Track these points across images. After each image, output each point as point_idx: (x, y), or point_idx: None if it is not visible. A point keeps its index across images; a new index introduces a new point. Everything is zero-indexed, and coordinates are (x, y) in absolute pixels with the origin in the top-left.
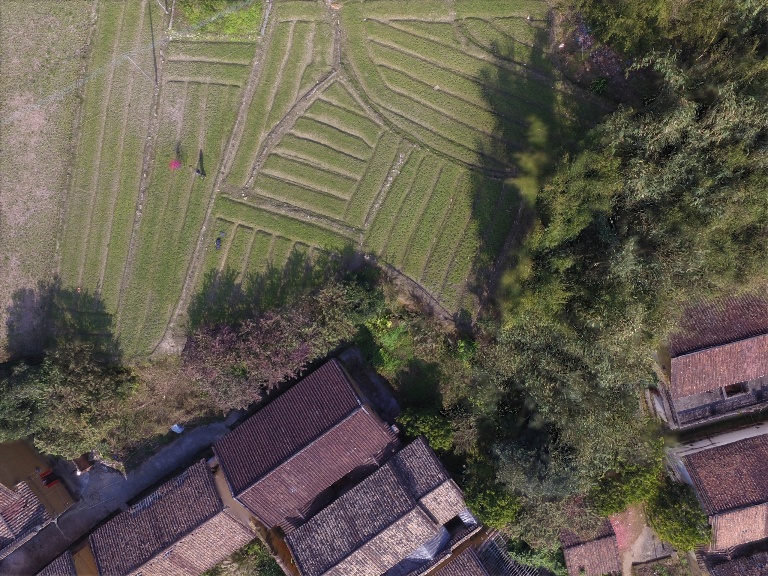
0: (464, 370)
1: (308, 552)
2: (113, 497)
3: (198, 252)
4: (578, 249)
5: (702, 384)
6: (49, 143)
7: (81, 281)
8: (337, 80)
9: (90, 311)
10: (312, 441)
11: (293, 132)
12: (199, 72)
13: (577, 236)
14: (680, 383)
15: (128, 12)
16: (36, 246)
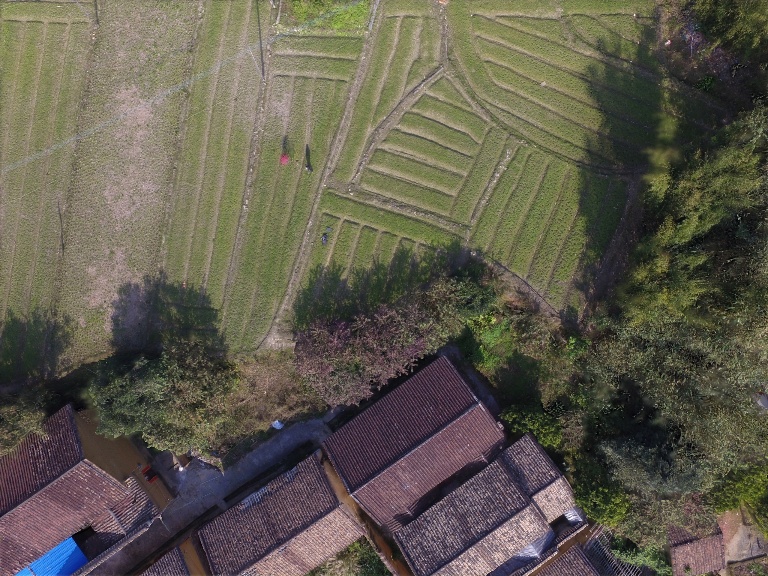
0: None
1: (419, 549)
2: (210, 493)
3: (304, 247)
4: (705, 246)
5: None
6: (155, 137)
7: (186, 276)
8: (444, 76)
9: (195, 306)
10: (429, 437)
11: (399, 127)
12: (306, 67)
13: (705, 232)
14: None
15: (235, 6)
16: (142, 240)
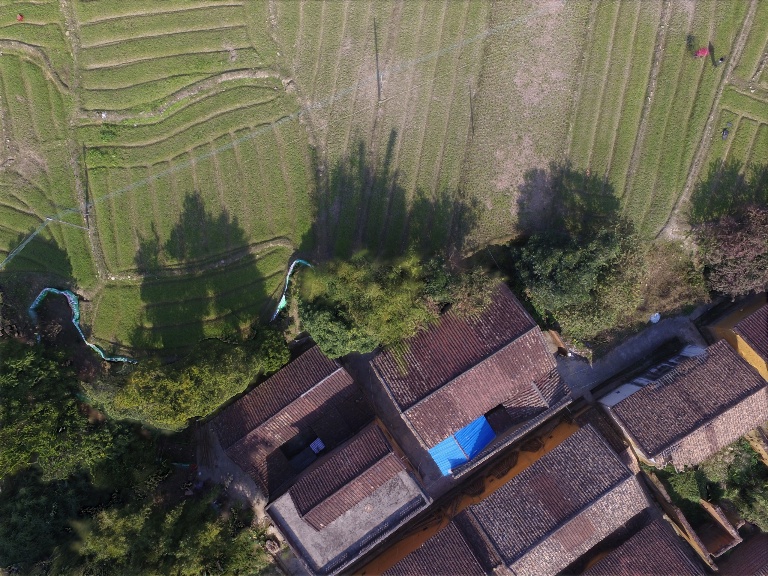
0: None
1: None
2: (578, 385)
3: (705, 141)
4: None
5: None
6: (565, 27)
7: (589, 164)
8: None
9: (598, 194)
10: None
11: None
12: None
13: None
14: None
15: None
16: (549, 127)
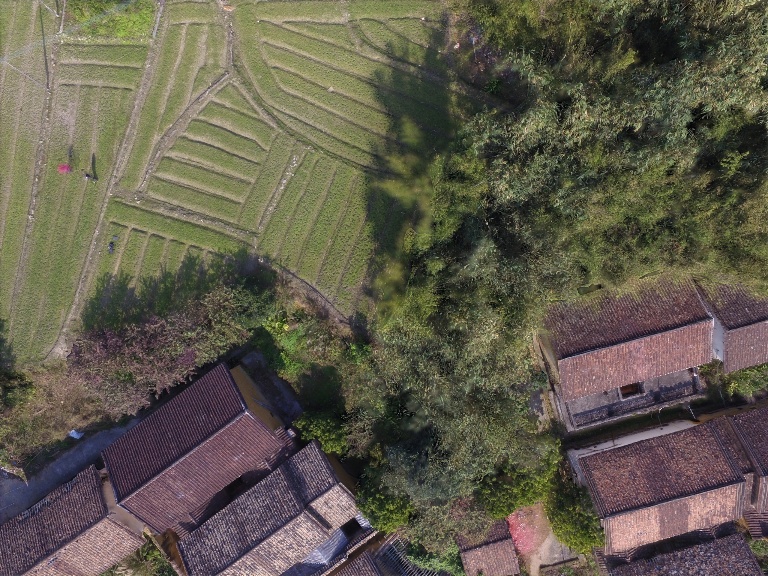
0: (367, 373)
1: (197, 558)
2: (14, 503)
3: (91, 256)
4: (454, 251)
5: (593, 386)
6: None
7: None
8: (230, 82)
9: None
10: (196, 446)
11: (186, 135)
12: (91, 75)
13: (452, 238)
14: (570, 385)
15: (19, 15)
16: None
